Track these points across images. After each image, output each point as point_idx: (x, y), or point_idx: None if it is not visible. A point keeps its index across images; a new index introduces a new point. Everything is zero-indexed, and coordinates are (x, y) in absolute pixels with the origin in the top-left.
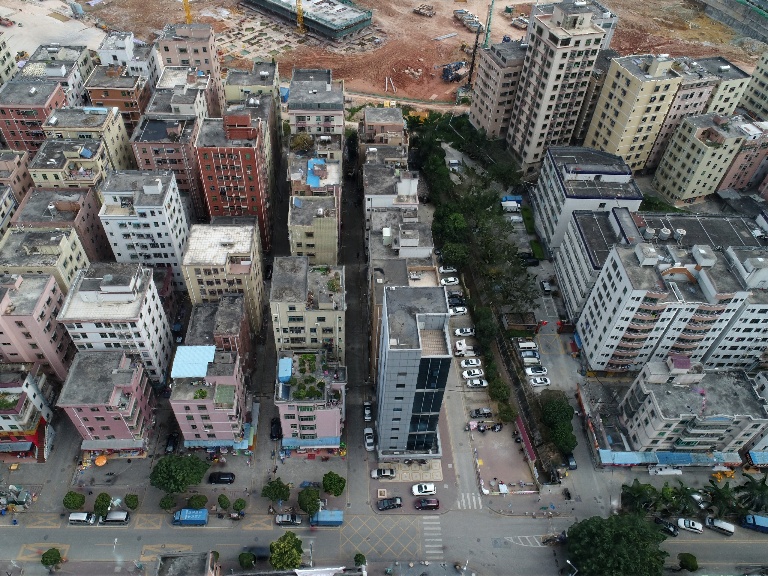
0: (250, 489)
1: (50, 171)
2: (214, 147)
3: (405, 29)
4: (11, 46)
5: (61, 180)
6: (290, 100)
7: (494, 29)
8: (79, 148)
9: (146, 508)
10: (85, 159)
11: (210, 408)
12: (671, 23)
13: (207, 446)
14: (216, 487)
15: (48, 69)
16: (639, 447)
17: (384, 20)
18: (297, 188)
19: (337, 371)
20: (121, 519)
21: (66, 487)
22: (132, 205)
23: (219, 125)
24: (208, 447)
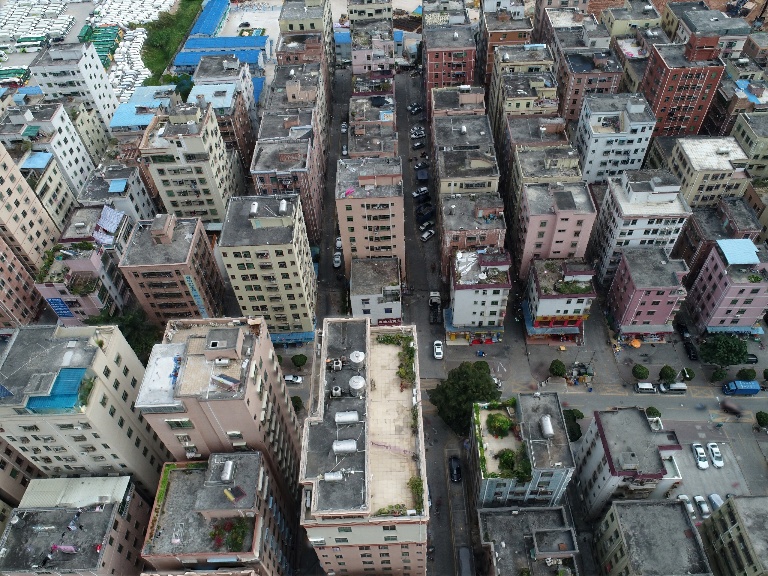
0: None
1: (525, 99)
2: (687, 68)
3: None
4: None
5: (530, 108)
6: (699, 28)
7: None
8: None
9: (692, 382)
10: (550, 88)
11: (761, 291)
12: None
13: (727, 331)
14: (743, 366)
15: (453, 17)
16: None
17: None
18: (740, 106)
19: None
20: (683, 388)
21: (614, 365)
22: None
23: (670, 50)
24: None
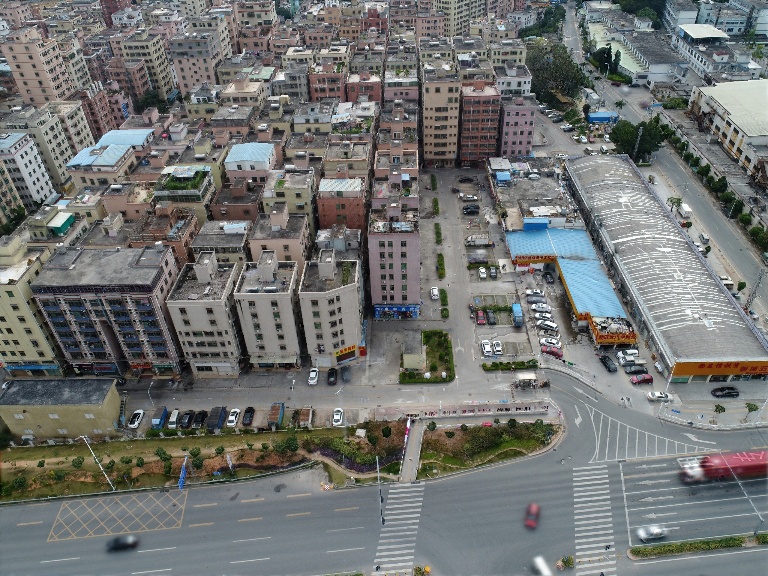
0: None
1: None
2: None
3: None
4: None
5: None
6: (88, 1)
7: None
8: None
9: None
10: (96, 20)
11: None
12: (31, 6)
13: None
14: None
15: (4, 31)
16: None
17: None
18: None
19: None
20: None
21: None
22: None
23: None
24: None
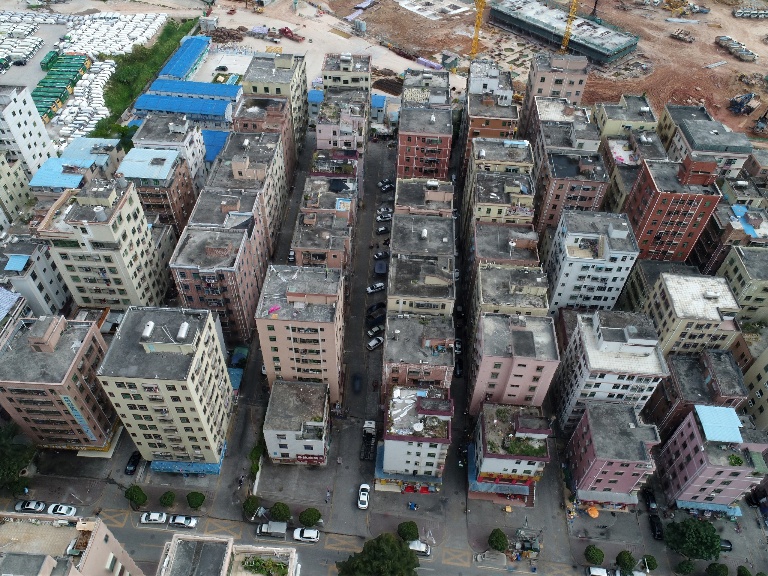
0: (751, 560)
1: (497, 206)
2: (678, 193)
3: (669, 55)
4: (310, 62)
5: (502, 215)
6: (696, 141)
7: (763, 58)
8: (519, 183)
9: None
10: (526, 195)
11: (741, 475)
12: None
13: (700, 509)
14: None
15: (434, 96)
16: None
17: (642, 44)
18: (734, 237)
19: None
20: None
21: (565, 536)
22: (598, 248)
23: (662, 168)
24: (699, 509)
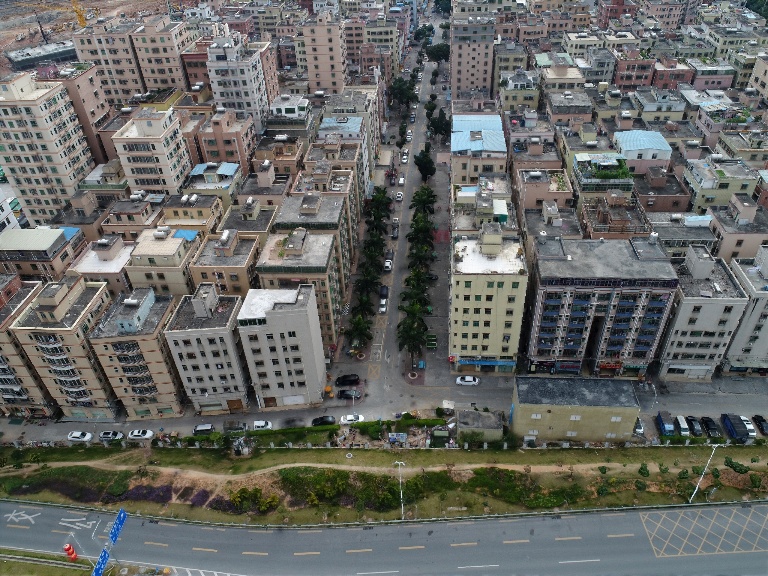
0: None
1: (304, 11)
2: None
3: None
4: None
5: None
6: None
7: None
8: None
9: None
10: None
11: None
12: None
13: None
14: None
15: (216, 16)
16: (422, 3)
17: None
18: None
19: (402, 1)
20: None
21: None
22: None
23: None
24: None
